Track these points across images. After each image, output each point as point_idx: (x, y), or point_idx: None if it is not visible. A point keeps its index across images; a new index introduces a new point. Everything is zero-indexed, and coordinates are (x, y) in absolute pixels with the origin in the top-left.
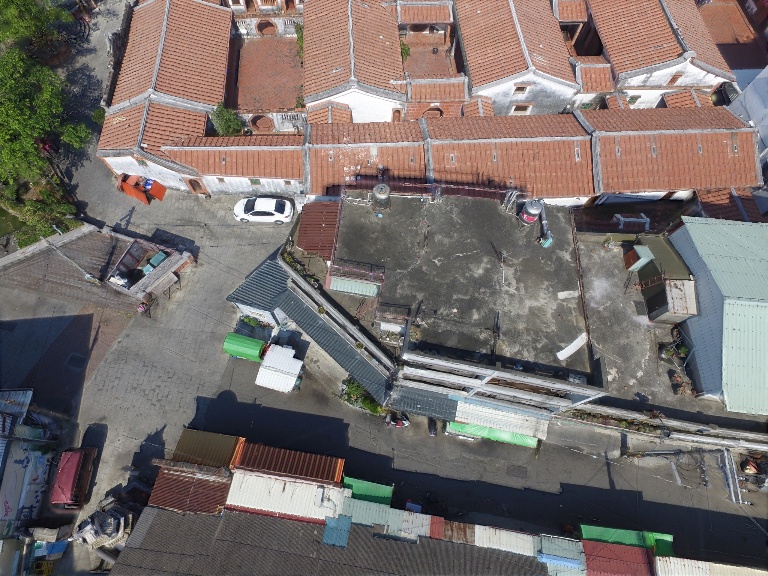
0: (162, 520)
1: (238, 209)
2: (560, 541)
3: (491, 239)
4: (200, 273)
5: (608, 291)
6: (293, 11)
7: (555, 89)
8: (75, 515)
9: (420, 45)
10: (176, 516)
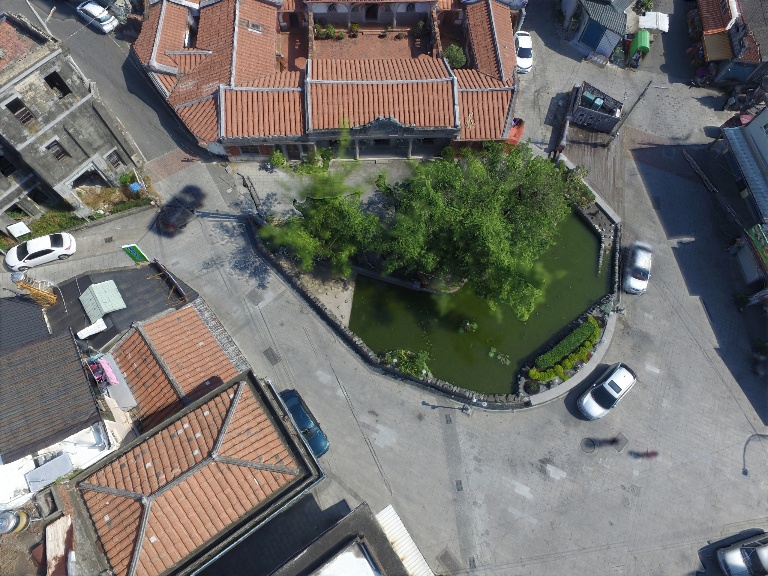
0: (767, 52)
1: (527, 62)
2: None
3: None
4: None
5: None
6: None
7: None
8: None
9: None
10: (762, 48)
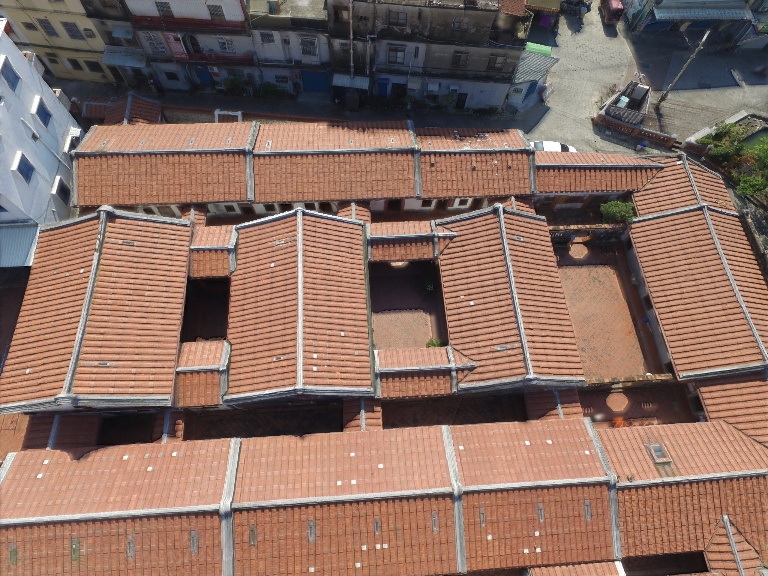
0: None
1: (574, 150)
2: None
3: None
4: (586, 113)
5: None
6: None
7: None
8: (603, 4)
9: None
10: None
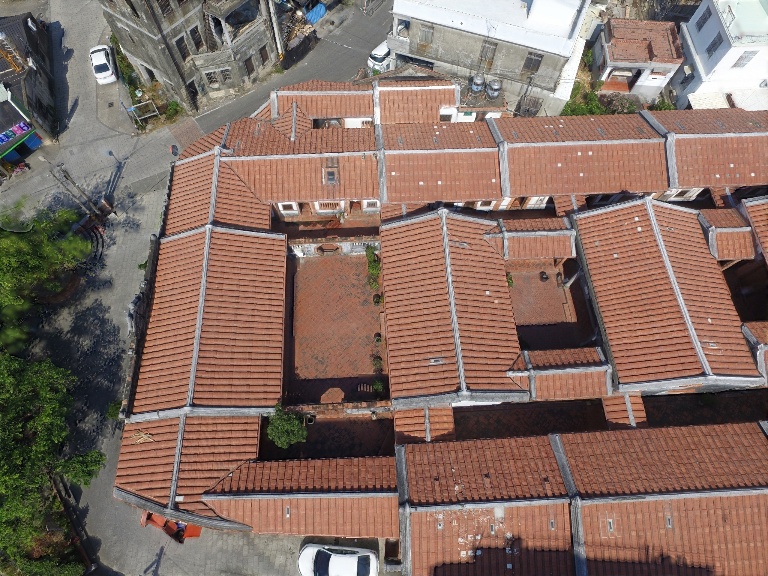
0: None
1: (305, 568)
2: None
3: None
4: None
5: None
6: (358, 212)
7: None
8: None
9: (523, 267)
10: None
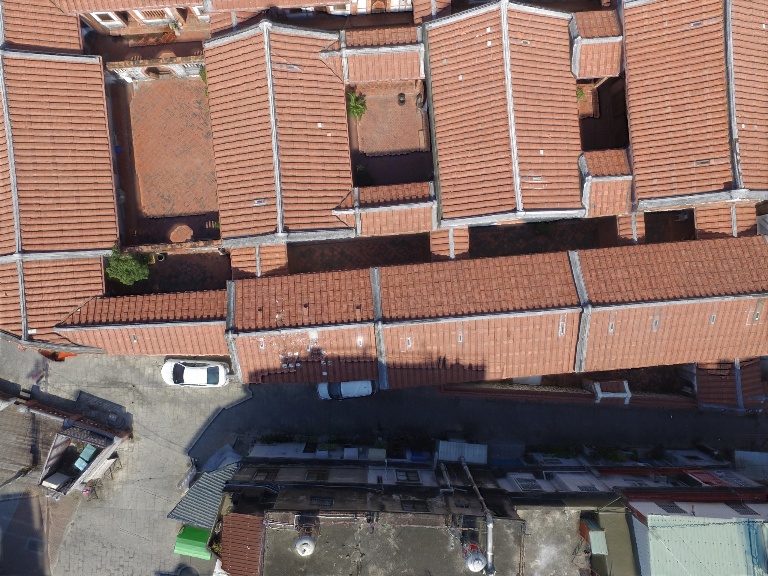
0: None
1: (166, 377)
2: None
3: (430, 568)
4: (138, 449)
5: (555, 559)
6: (195, 20)
7: None
8: None
9: (381, 88)
10: None
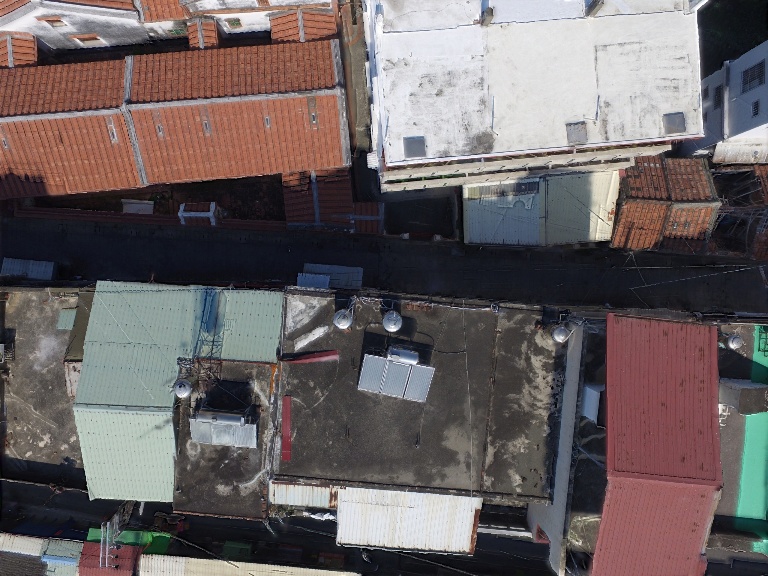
0: None
1: None
2: (66, 543)
3: None
4: None
5: (55, 350)
6: None
7: (104, 19)
8: None
9: None
10: None
